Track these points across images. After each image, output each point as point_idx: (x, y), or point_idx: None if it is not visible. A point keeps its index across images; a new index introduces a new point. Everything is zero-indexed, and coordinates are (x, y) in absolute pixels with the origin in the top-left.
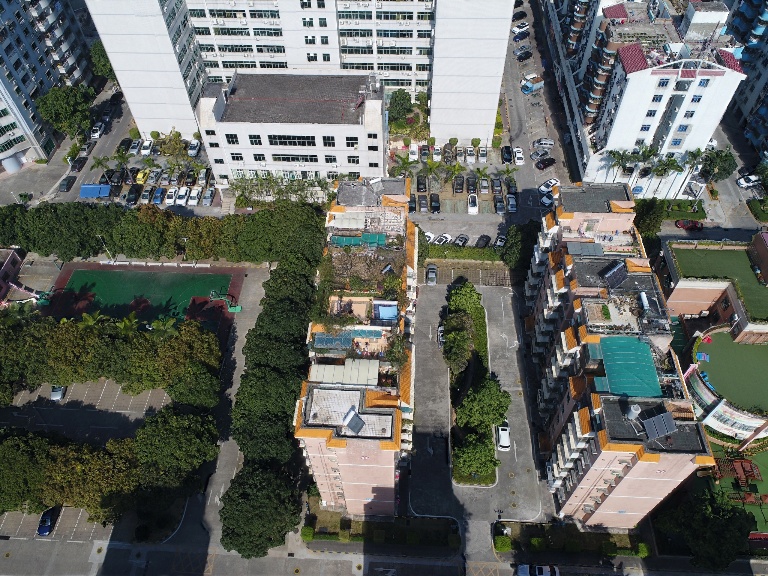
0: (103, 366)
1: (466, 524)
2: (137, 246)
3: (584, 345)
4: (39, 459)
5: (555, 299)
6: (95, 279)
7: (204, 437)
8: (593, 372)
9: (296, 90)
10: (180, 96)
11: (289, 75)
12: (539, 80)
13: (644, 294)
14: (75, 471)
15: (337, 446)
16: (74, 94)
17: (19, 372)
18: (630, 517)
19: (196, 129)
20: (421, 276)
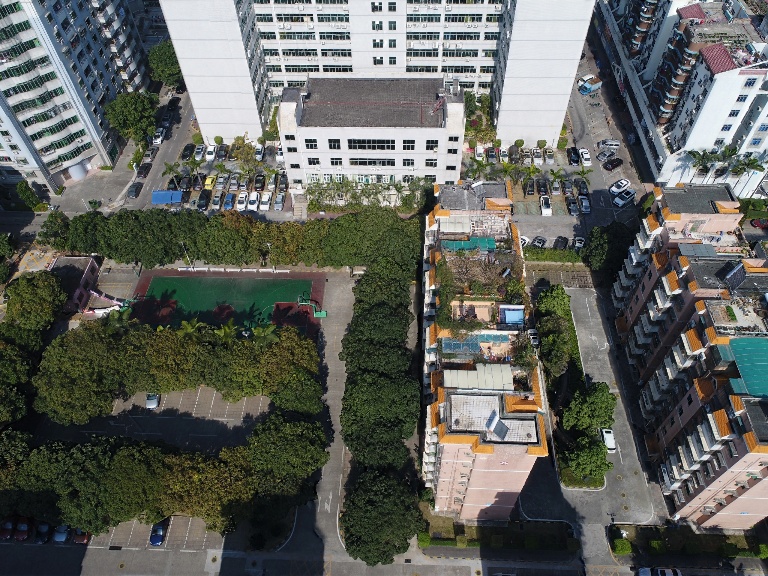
0: (204, 374)
1: (580, 527)
2: (222, 252)
3: (711, 347)
4: (156, 468)
5: (667, 301)
6: (175, 286)
7: (316, 444)
8: (721, 374)
9: (371, 94)
10: (247, 101)
11: (361, 79)
12: (597, 81)
13: None
14: (192, 480)
15: (484, 452)
16: (142, 100)
17: (118, 381)
18: (750, 518)
19: (260, 134)
20: None
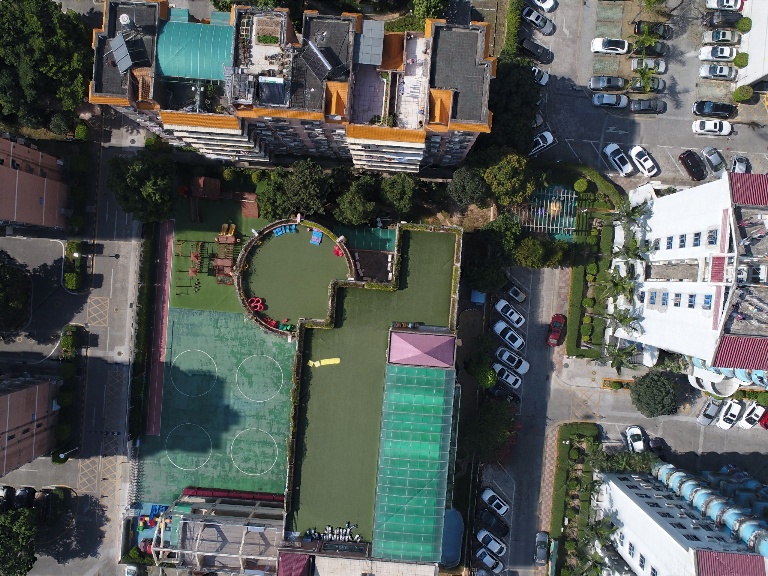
0: None
1: None
2: None
3: None
4: None
5: None
6: None
7: None
8: None
9: None
10: None
11: None
12: None
13: (280, 79)
14: None
15: None
16: None
17: None
18: None
19: None
20: None
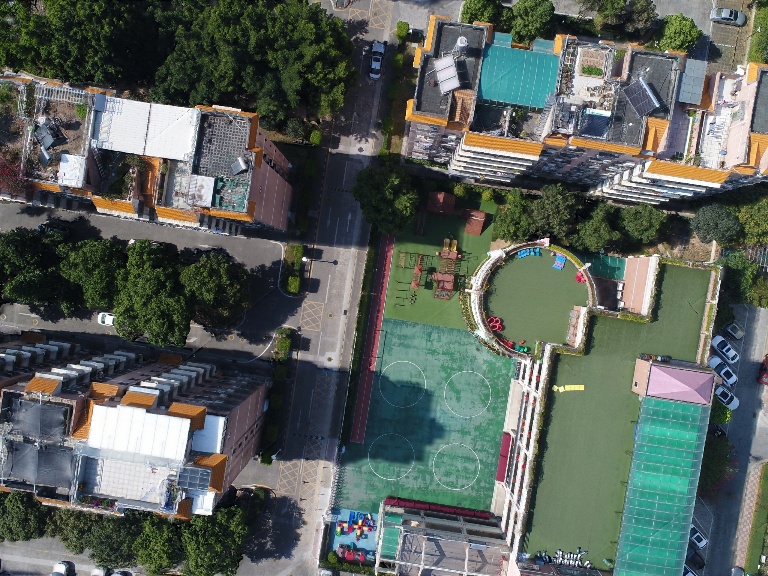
0: None
1: (425, 7)
2: None
3: None
4: None
5: None
6: None
7: None
8: None
9: None
10: None
11: None
12: None
13: (608, 113)
14: None
15: None
16: None
17: None
18: None
19: None
20: (728, 5)
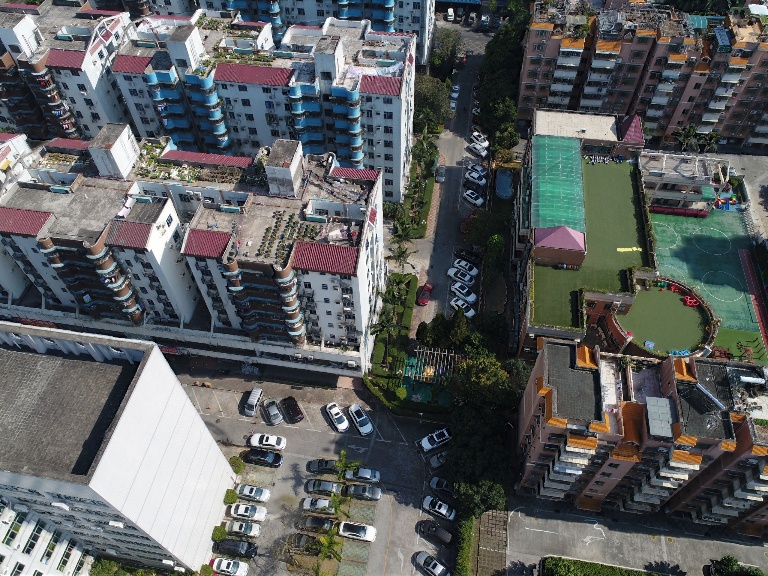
0: None
1: None
2: None
3: None
4: None
5: None
6: None
7: None
8: None
9: None
10: None
11: None
12: None
13: (744, 378)
14: None
15: None
16: None
17: None
18: None
19: None
20: None
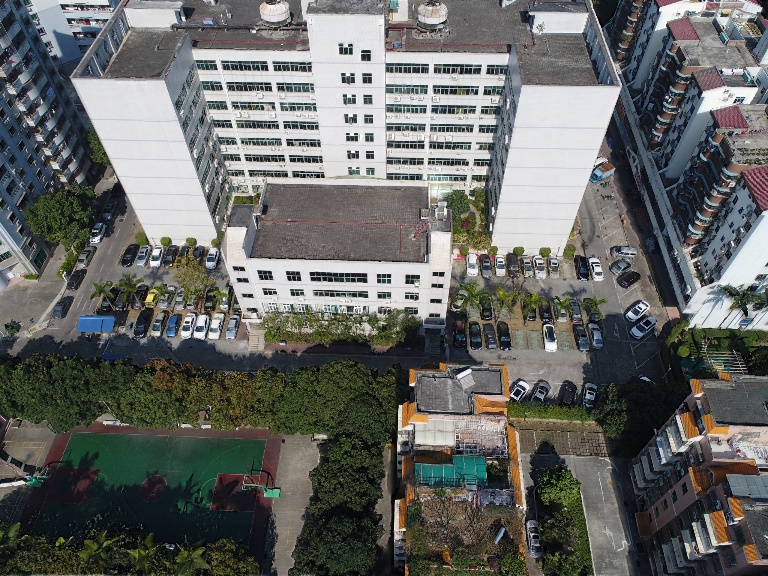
0: None
1: None
2: (150, 418)
3: None
4: None
5: (710, 548)
6: (98, 447)
7: None
8: None
9: (340, 208)
10: (197, 203)
11: (330, 186)
12: (609, 167)
13: None
14: None
15: None
16: (70, 203)
17: None
18: None
19: (215, 235)
20: None
